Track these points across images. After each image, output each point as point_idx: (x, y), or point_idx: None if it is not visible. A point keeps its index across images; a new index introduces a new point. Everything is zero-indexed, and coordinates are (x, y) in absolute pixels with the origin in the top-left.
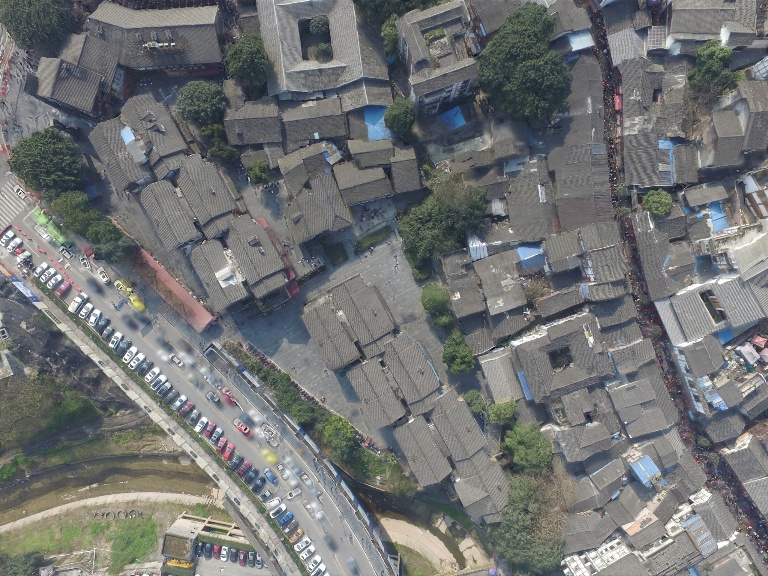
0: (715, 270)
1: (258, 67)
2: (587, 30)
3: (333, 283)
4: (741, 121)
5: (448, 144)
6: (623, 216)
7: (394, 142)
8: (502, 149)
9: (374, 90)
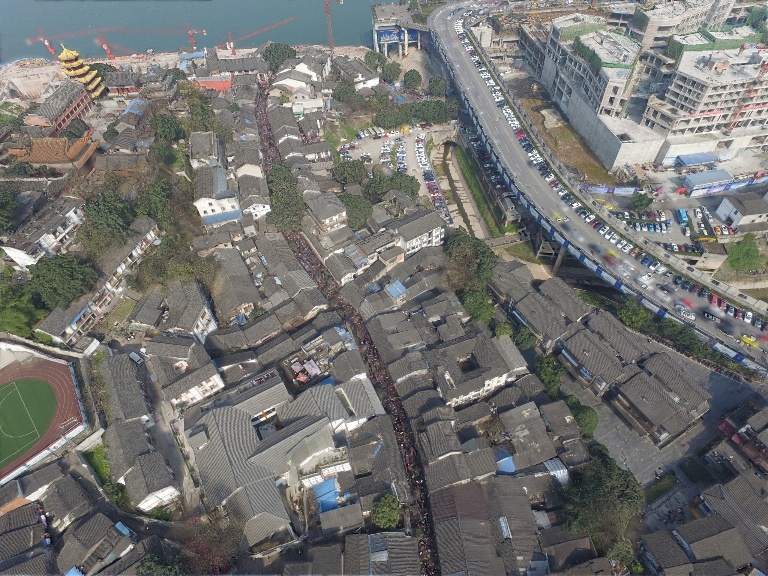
0: None
1: None
2: None
3: (683, 441)
4: None
5: None
6: None
7: None
8: None
9: None
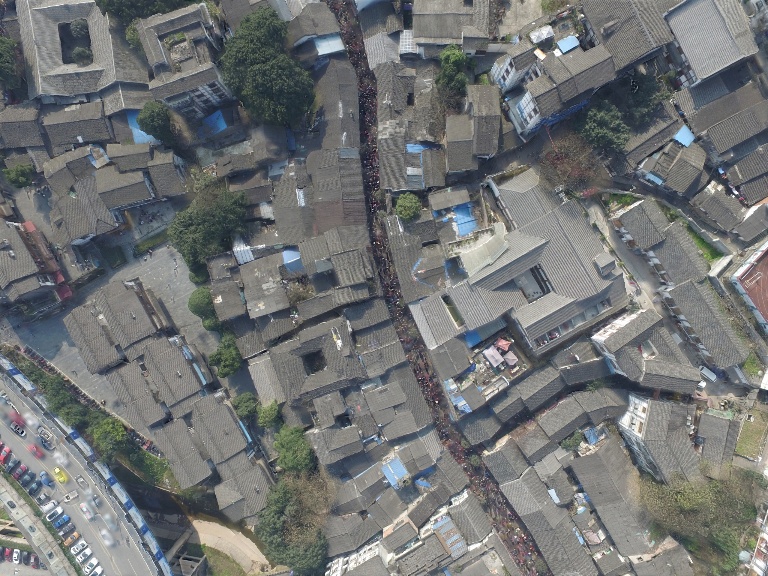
0: (463, 273)
1: (4, 71)
2: (336, 34)
3: None
4: (473, 125)
5: (219, 148)
6: (383, 219)
7: (156, 146)
8: (258, 153)
9: (133, 94)
